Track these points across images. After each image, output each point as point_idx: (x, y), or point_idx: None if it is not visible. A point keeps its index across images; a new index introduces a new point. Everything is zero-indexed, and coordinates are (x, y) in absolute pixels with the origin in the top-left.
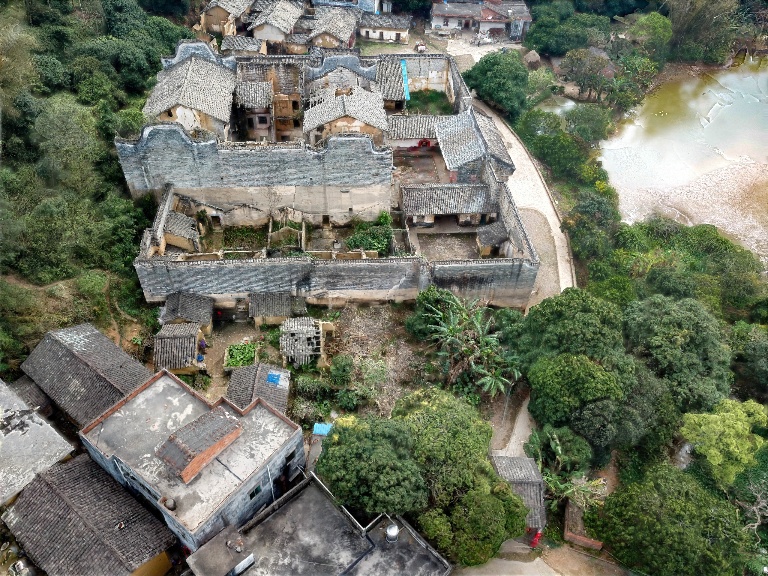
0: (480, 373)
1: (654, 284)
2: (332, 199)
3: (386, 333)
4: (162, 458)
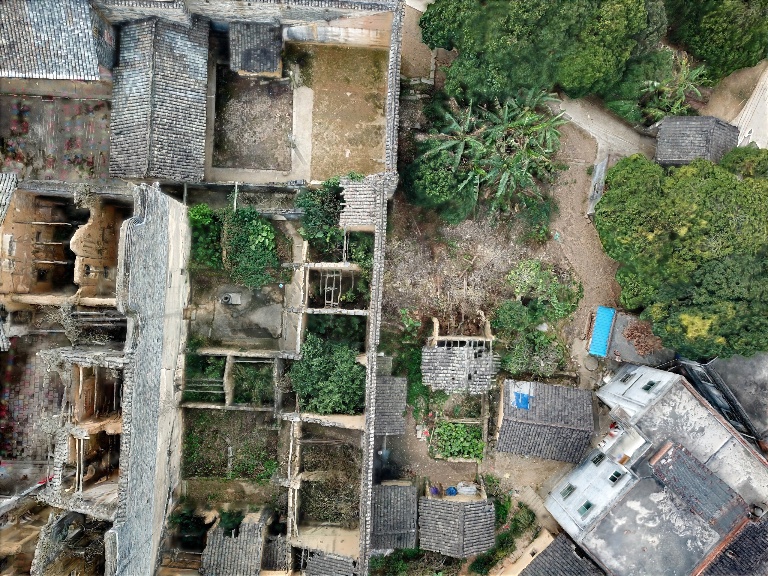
0: (542, 144)
1: None
2: (173, 303)
3: (426, 248)
4: (729, 529)
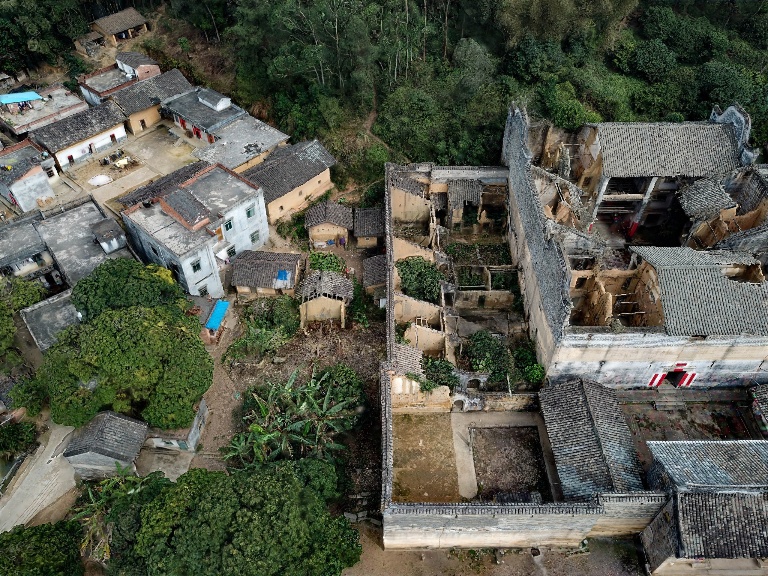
0: None
1: None
2: None
3: None
4: None
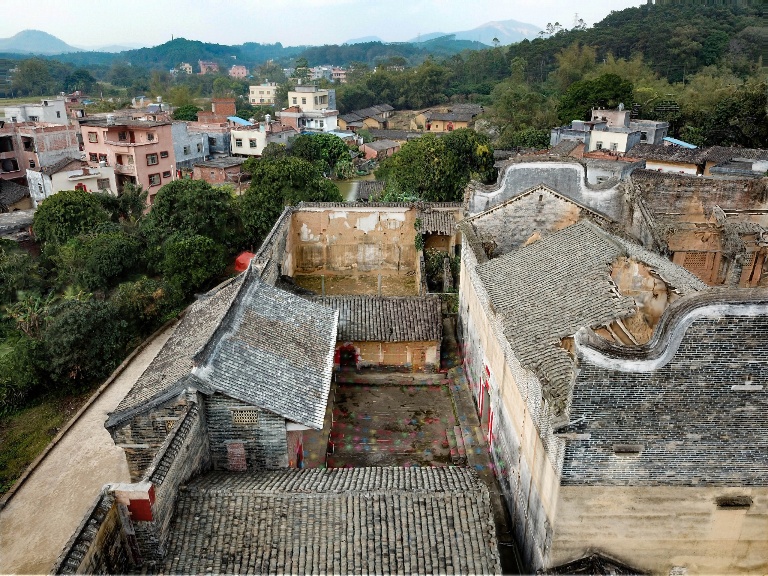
0: None
1: (127, 265)
2: None
3: None
4: None
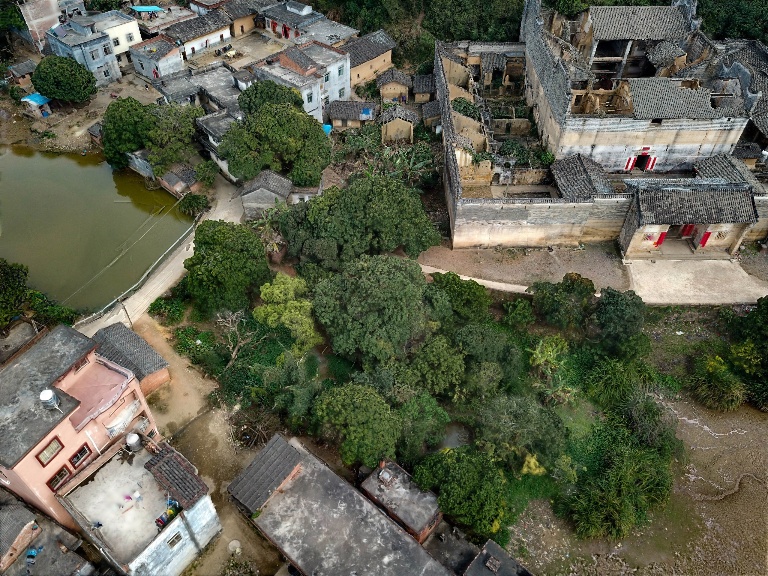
0: None
1: None
2: None
3: None
4: None
